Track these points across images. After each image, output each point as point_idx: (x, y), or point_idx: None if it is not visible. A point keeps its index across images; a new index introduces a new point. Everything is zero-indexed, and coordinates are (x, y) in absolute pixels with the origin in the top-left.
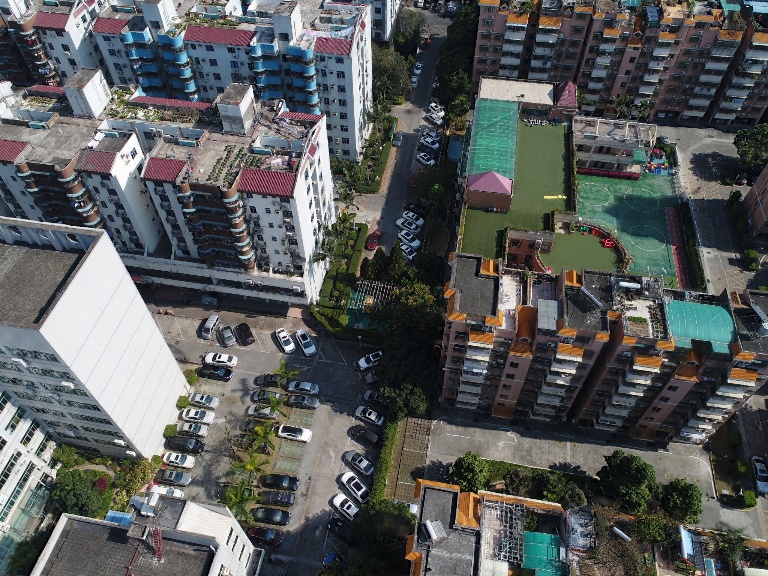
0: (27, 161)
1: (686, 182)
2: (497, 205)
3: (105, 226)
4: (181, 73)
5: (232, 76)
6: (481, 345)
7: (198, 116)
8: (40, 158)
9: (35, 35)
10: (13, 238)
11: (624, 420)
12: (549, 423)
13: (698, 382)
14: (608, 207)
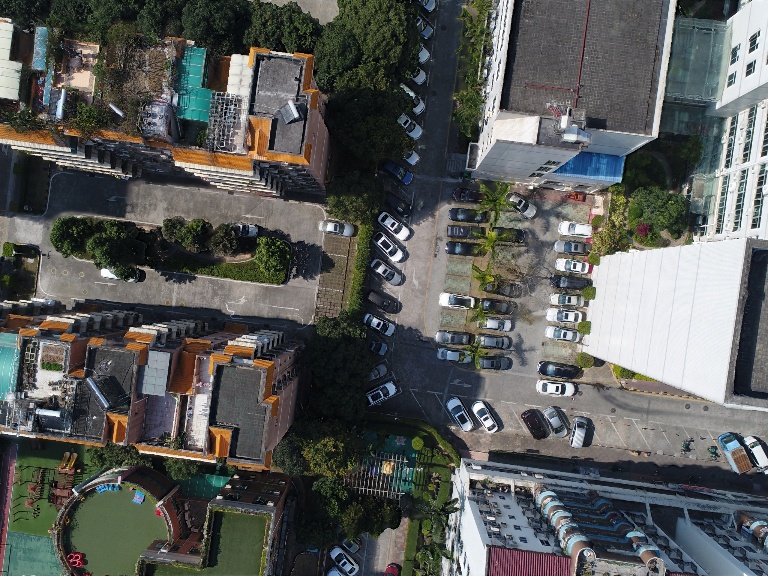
0: None
1: None
2: None
3: (755, 541)
4: None
5: None
6: (241, 344)
7: None
8: None
9: None
10: None
11: None
12: None
13: None
14: None
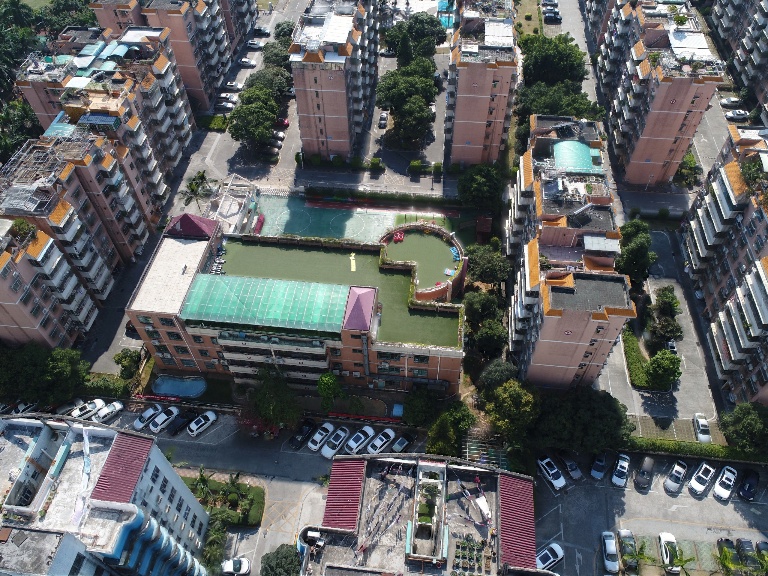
0: None
1: (270, 187)
2: None
3: None
4: None
5: None
6: None
7: None
8: None
9: None
10: None
11: None
12: None
13: None
14: None
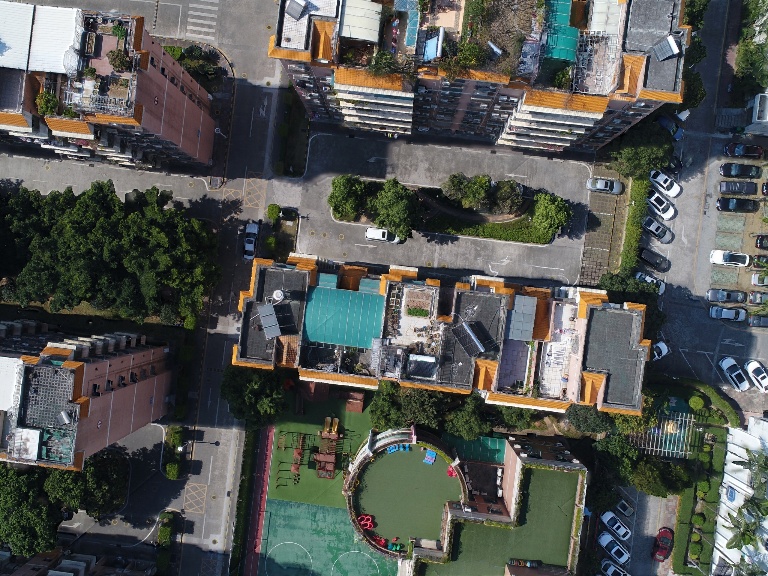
0: None
1: None
2: (526, 571)
3: None
4: None
5: None
6: (591, 291)
7: None
8: None
9: None
10: None
11: None
12: None
13: None
14: None
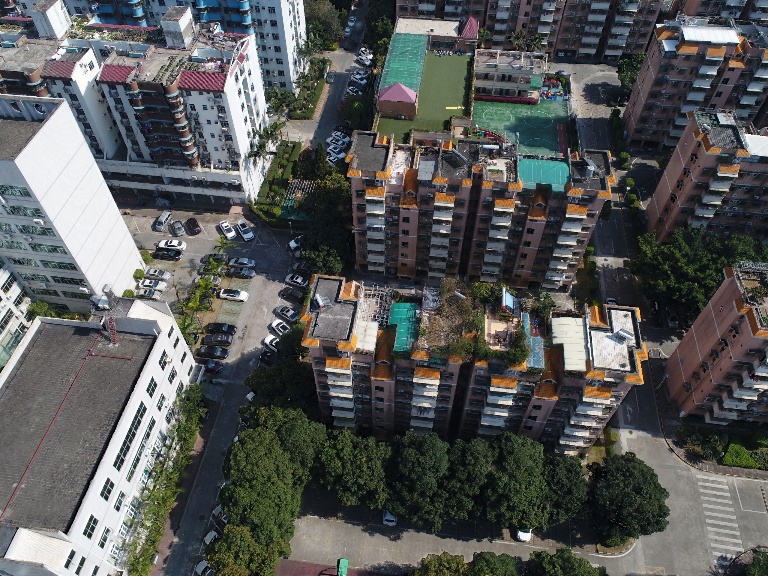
0: None
1: (577, 105)
2: (405, 113)
3: None
4: (134, 13)
5: None
6: (375, 198)
7: (146, 36)
8: (11, 68)
9: None
10: None
11: (503, 271)
12: None
13: (548, 223)
14: (509, 126)
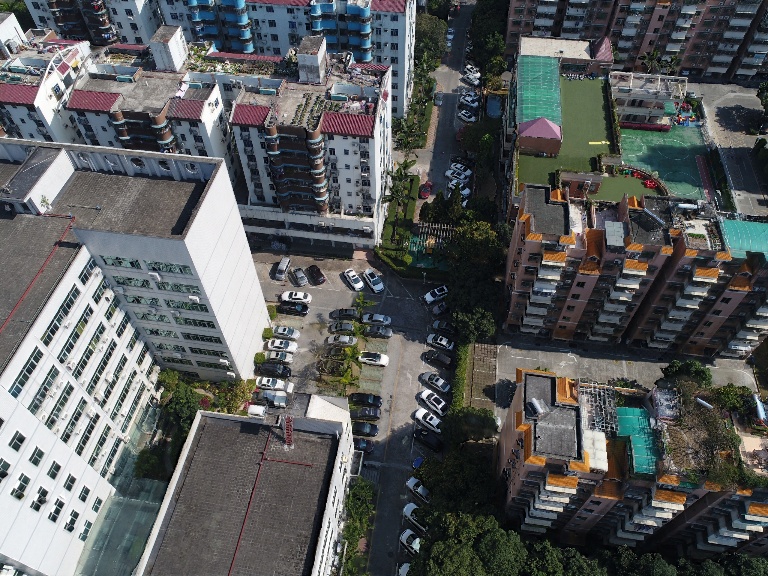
0: (121, 110)
1: (713, 133)
2: (547, 150)
3: None
4: (241, 34)
5: (289, 37)
6: (554, 264)
7: (273, 68)
8: (132, 107)
9: (101, 0)
10: (134, 170)
11: (676, 337)
12: (605, 345)
13: (750, 293)
14: (642, 156)
